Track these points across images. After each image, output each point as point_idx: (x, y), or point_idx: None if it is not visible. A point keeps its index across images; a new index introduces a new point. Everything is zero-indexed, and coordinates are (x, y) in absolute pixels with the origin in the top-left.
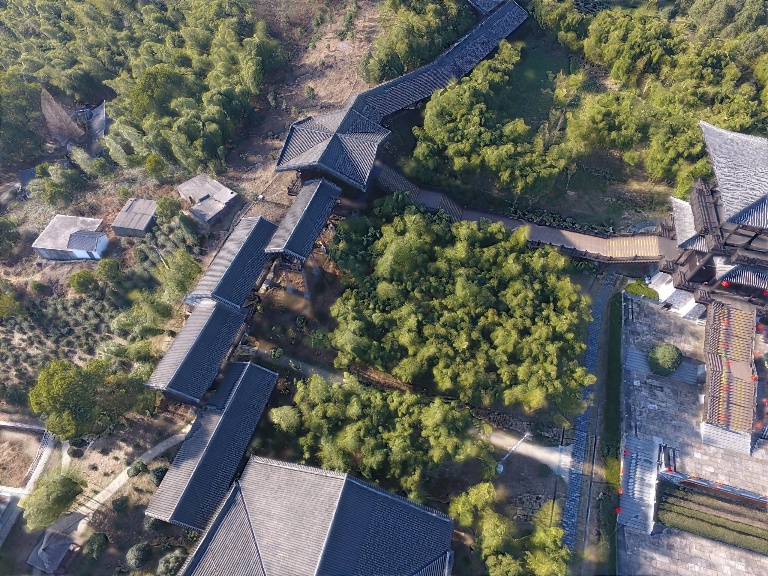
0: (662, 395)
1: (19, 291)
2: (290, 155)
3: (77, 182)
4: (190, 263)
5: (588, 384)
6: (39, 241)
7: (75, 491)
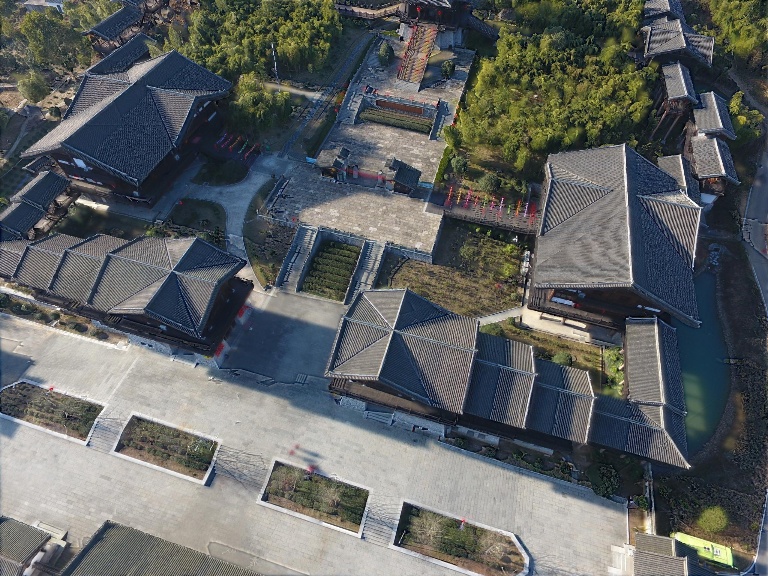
0: (382, 73)
1: None
2: None
3: None
4: (118, 8)
5: (327, 50)
6: (29, 2)
7: (44, 90)
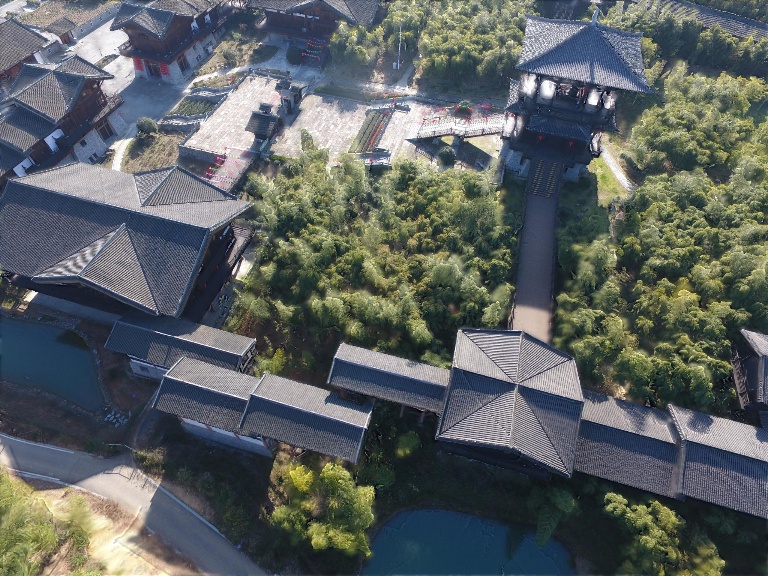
0: None
1: None
2: None
3: None
4: None
5: (436, 64)
6: None
7: None
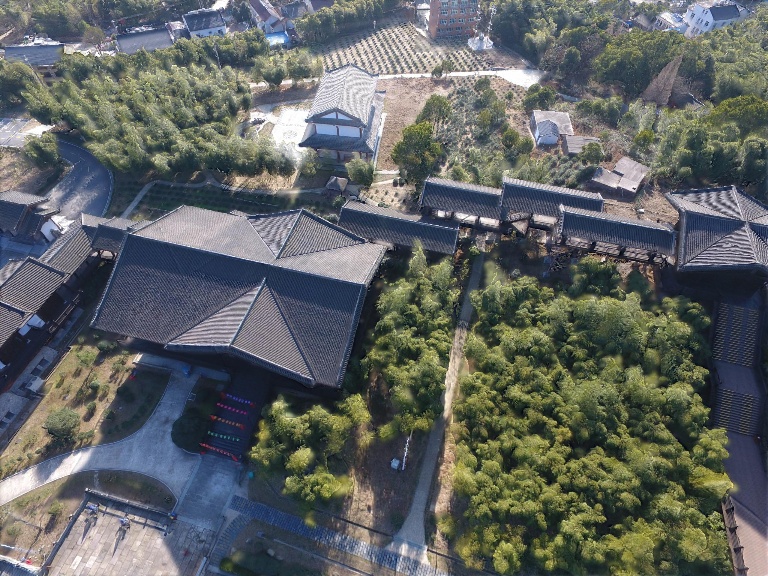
0: None
1: (502, 124)
2: (691, 197)
3: (610, 117)
4: None
5: None
6: (540, 112)
7: (368, 181)
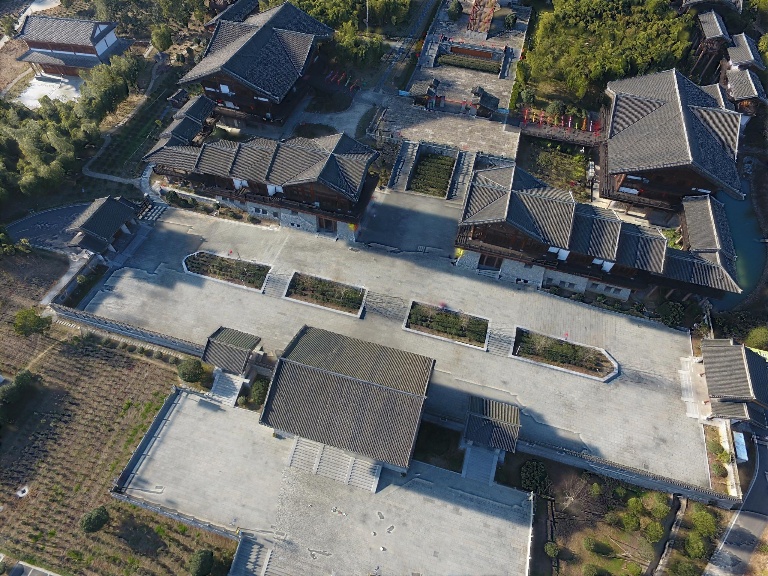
0: (452, 26)
1: None
2: None
3: None
4: None
5: (408, 5)
6: None
7: (170, 40)
